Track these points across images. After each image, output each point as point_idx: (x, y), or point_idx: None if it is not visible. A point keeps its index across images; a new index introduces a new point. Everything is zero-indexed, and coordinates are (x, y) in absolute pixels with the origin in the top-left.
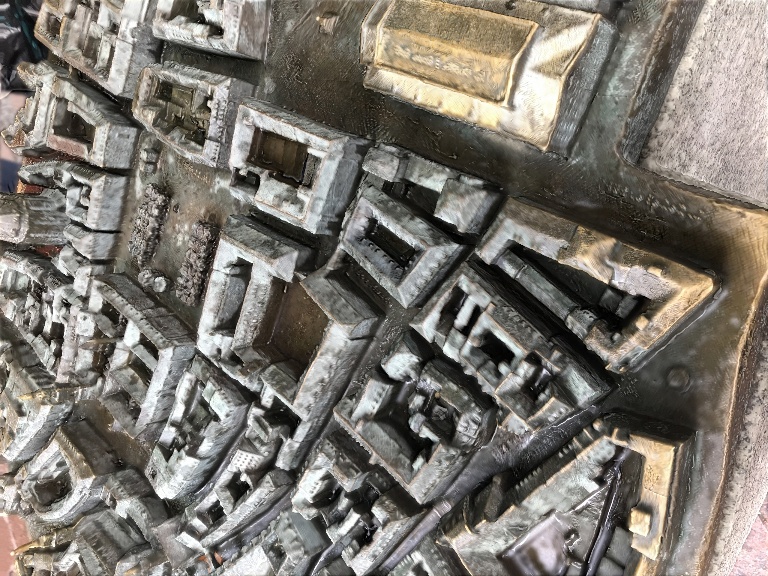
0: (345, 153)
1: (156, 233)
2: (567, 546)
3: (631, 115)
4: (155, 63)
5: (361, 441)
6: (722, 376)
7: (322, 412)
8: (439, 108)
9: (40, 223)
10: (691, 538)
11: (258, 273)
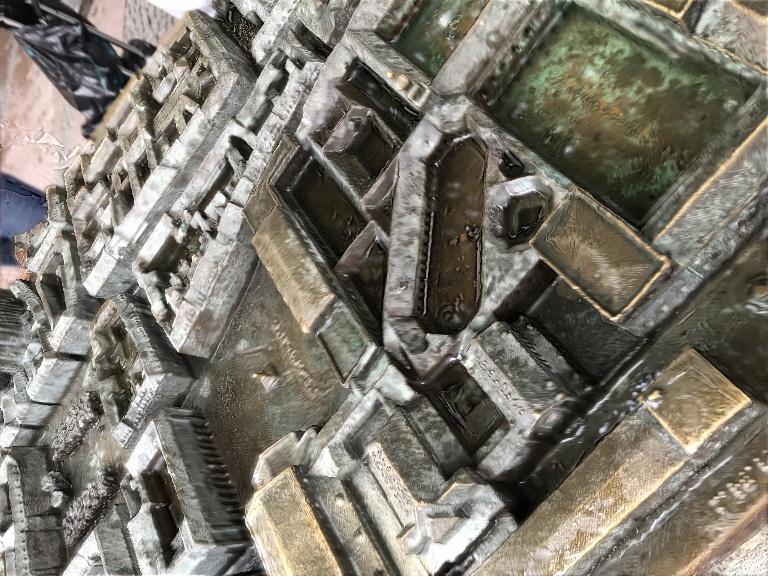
0: (209, 555)
1: (78, 439)
2: None
3: None
4: (123, 298)
5: None
6: None
7: None
8: None
9: None
10: None
11: None
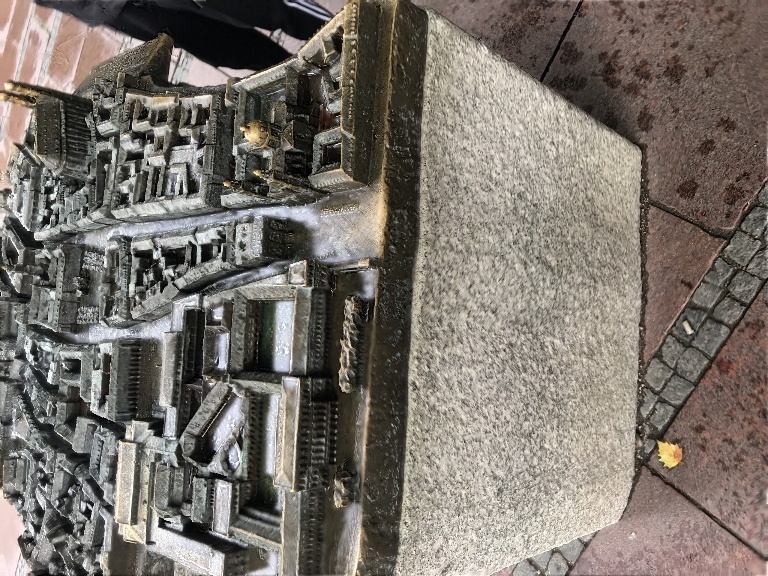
0: None
1: None
2: None
3: None
4: (125, 248)
5: None
6: None
7: None
8: None
9: (68, 175)
10: None
11: None
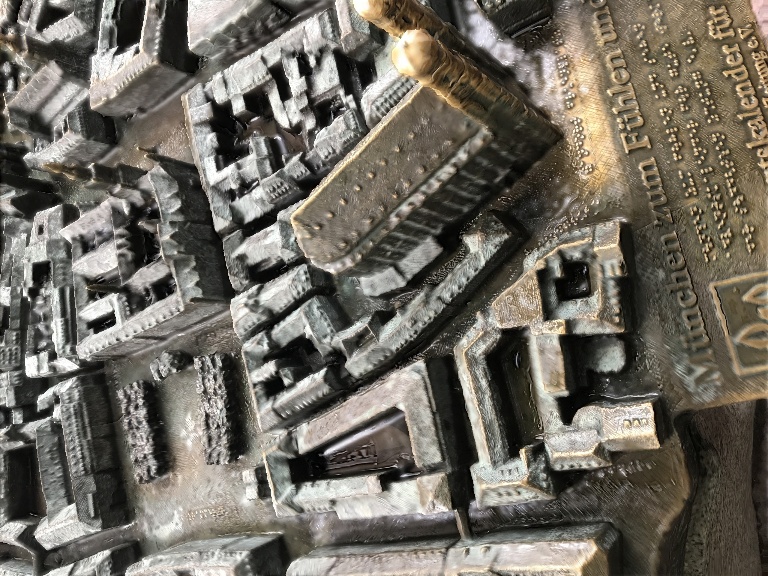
0: None
1: None
2: None
3: None
4: None
5: None
6: None
7: None
8: None
9: None
10: None
11: None
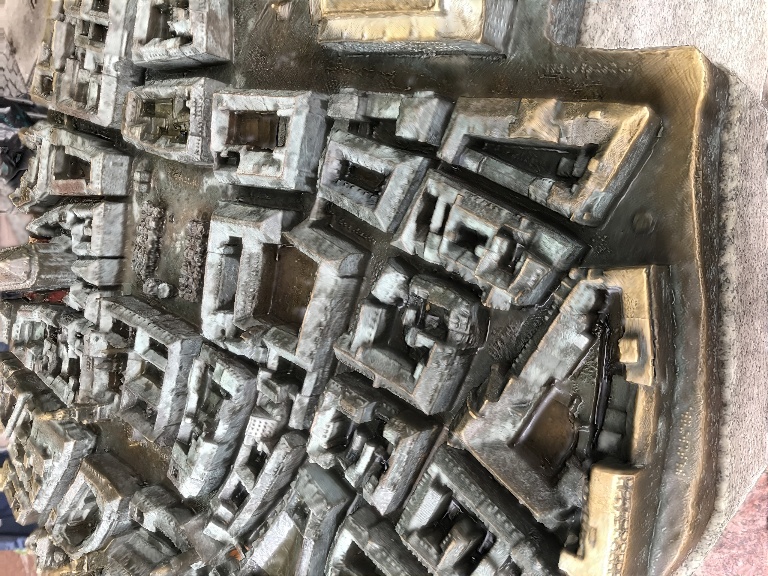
0: (311, 107)
1: (156, 246)
2: (572, 413)
3: (553, 2)
4: None
5: (363, 369)
6: (681, 206)
7: (326, 362)
8: (384, 37)
9: (49, 264)
10: (687, 372)
11: (249, 242)
